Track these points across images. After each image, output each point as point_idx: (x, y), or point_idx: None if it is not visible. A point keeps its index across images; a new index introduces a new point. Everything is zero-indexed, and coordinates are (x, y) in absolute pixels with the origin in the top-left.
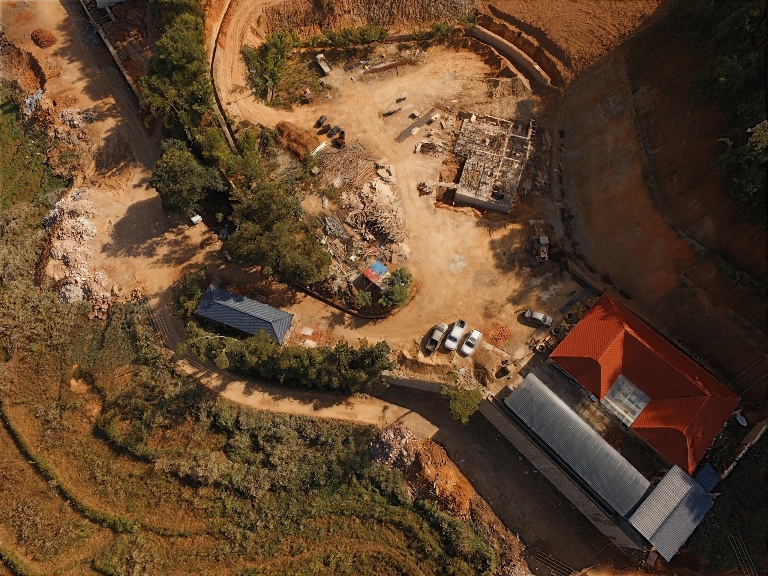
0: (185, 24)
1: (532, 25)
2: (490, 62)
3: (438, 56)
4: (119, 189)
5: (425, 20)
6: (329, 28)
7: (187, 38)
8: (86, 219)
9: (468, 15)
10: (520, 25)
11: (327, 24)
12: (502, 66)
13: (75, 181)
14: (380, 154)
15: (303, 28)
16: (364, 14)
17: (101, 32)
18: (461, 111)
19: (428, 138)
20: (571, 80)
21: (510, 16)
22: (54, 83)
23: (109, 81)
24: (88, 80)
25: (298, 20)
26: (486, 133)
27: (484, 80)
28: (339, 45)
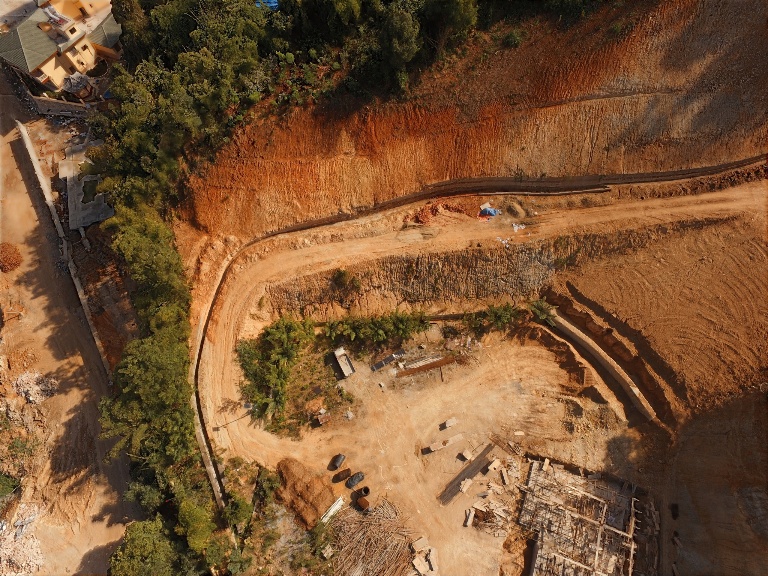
0: (163, 321)
1: (628, 325)
2: (568, 367)
3: (496, 351)
4: (74, 523)
5: (480, 296)
6: (352, 306)
7: (161, 363)
8: (27, 575)
9: (537, 291)
10: (611, 319)
11: (350, 300)
12: (585, 380)
13: (23, 494)
14: (417, 524)
15: (318, 305)
16: (399, 289)
17: (71, 267)
18: (529, 452)
19: (484, 499)
20: (686, 419)
21: (597, 304)
22: (12, 329)
23: (78, 329)
24: (53, 327)
25: (312, 298)
26: (567, 513)
27: (560, 399)
28: (365, 338)
